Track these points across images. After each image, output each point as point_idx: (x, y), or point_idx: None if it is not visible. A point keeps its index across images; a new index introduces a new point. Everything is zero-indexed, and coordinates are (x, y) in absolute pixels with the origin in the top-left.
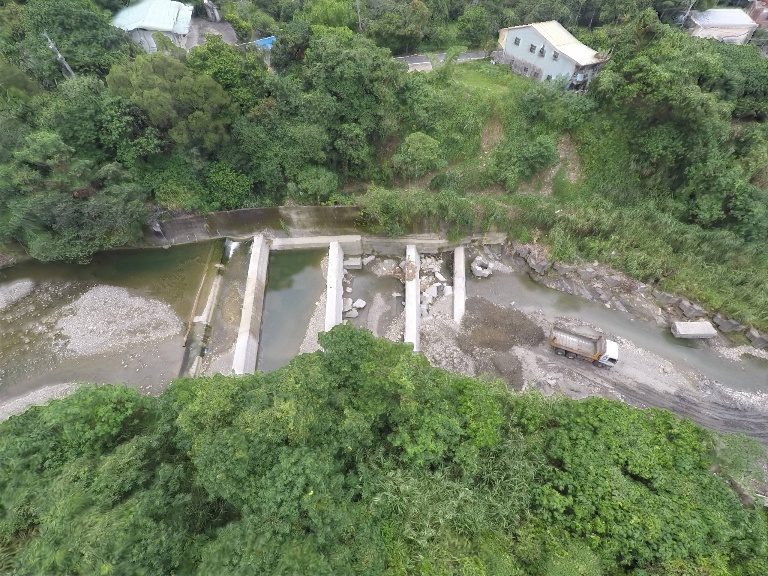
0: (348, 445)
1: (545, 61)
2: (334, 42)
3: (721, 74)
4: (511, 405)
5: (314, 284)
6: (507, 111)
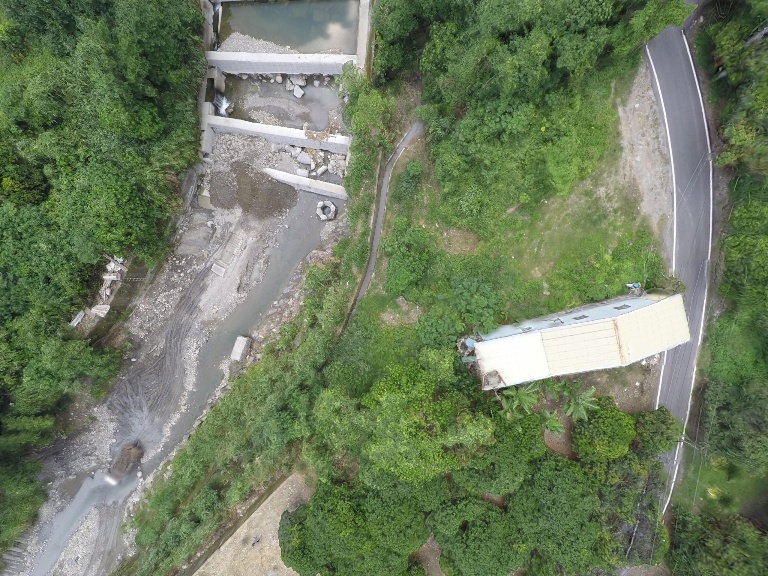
0: (76, 23)
1: (537, 321)
2: None
3: None
4: (148, 158)
5: (313, 44)
6: (477, 258)
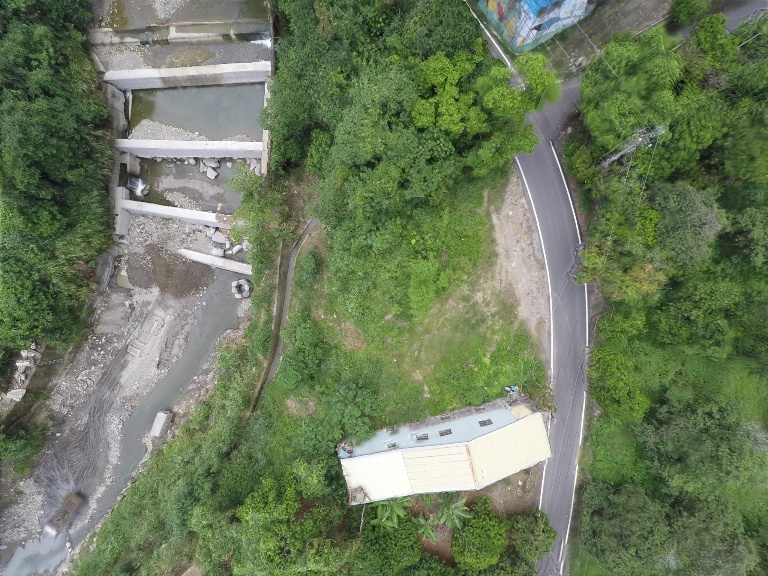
0: None
1: (406, 433)
2: (382, 98)
3: None
4: (53, 252)
5: (222, 130)
6: (362, 359)
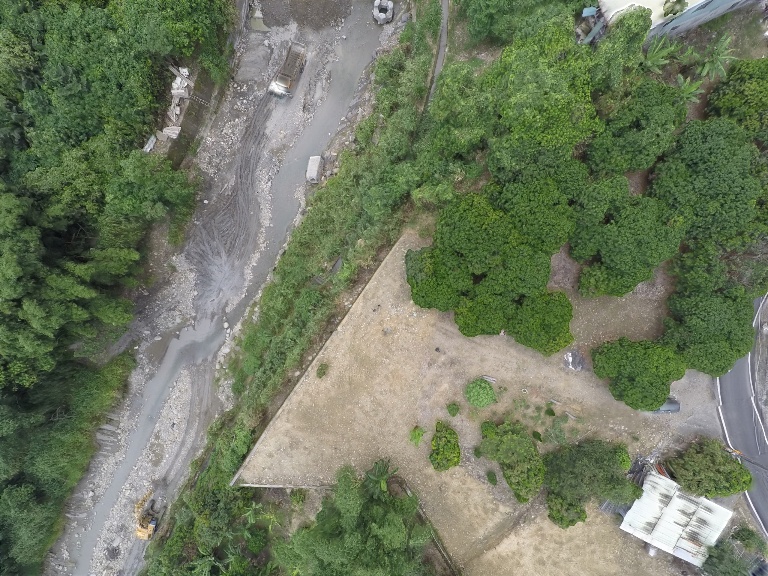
0: None
1: None
2: None
3: (505, 123)
4: None
5: None
6: None
